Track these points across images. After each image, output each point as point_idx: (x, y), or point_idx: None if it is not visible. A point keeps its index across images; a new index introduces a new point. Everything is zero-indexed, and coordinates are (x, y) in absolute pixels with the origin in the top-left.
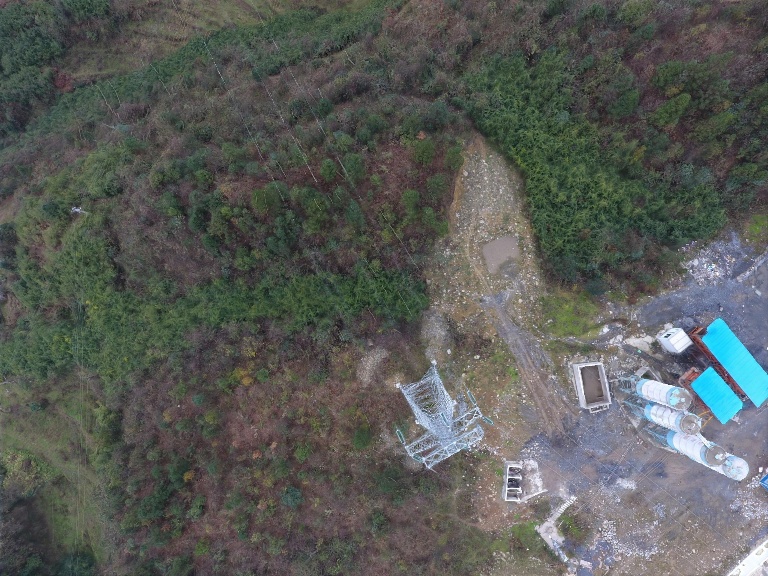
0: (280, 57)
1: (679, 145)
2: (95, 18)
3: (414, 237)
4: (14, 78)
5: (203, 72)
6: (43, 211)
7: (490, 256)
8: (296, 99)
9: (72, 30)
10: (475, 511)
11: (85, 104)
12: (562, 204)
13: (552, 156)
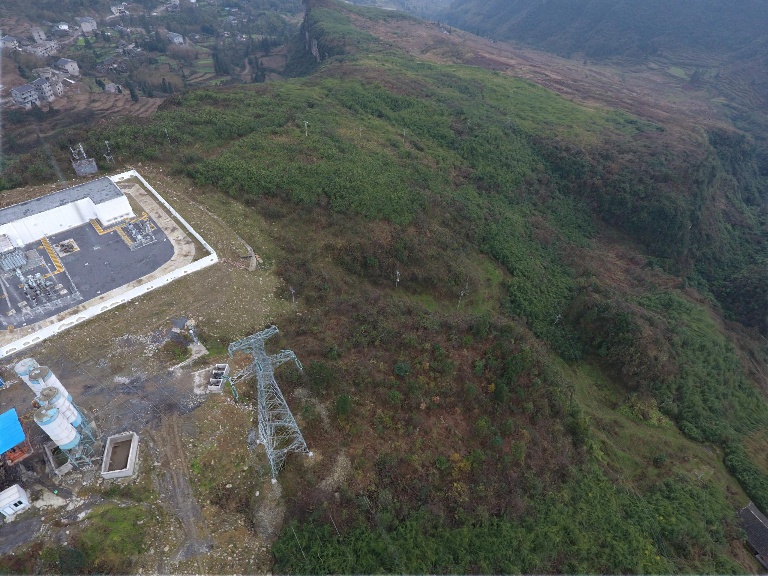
0: None
1: None
2: None
3: None
4: None
5: None
6: None
7: None
8: None
9: None
10: None
11: None
12: None
13: None
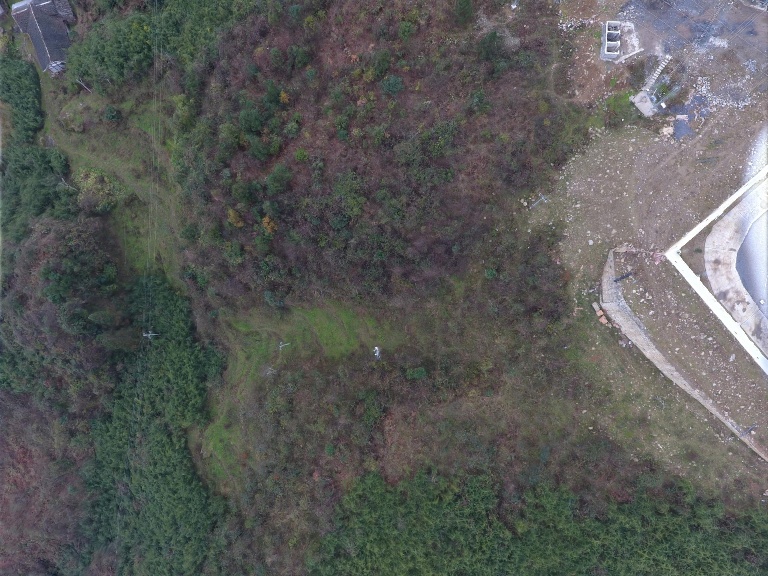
0: None
1: None
2: None
3: None
4: None
5: None
6: None
7: None
8: None
9: None
10: (572, 84)
11: None
12: None
13: None
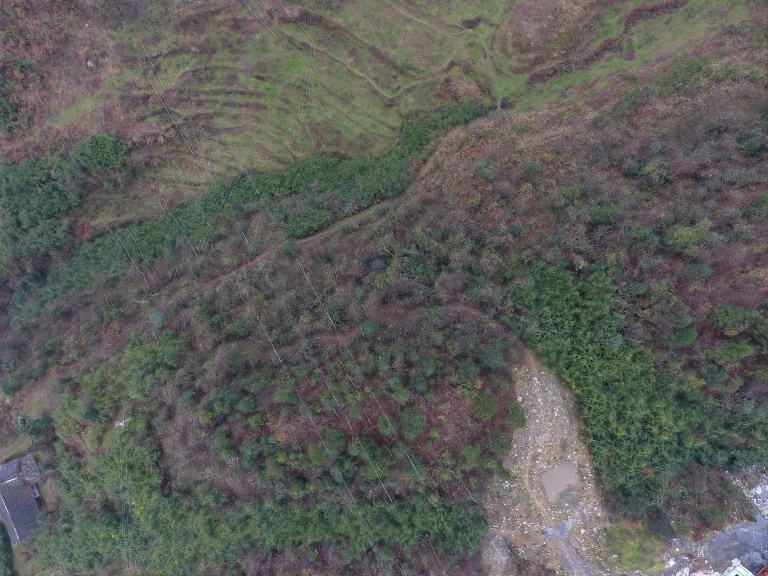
0: (308, 222)
1: (739, 379)
2: (112, 172)
3: (473, 476)
4: (33, 233)
5: (227, 229)
6: (82, 413)
7: (549, 485)
8: (336, 302)
9: (88, 180)
10: None
11: (107, 256)
12: (622, 437)
13: (607, 381)
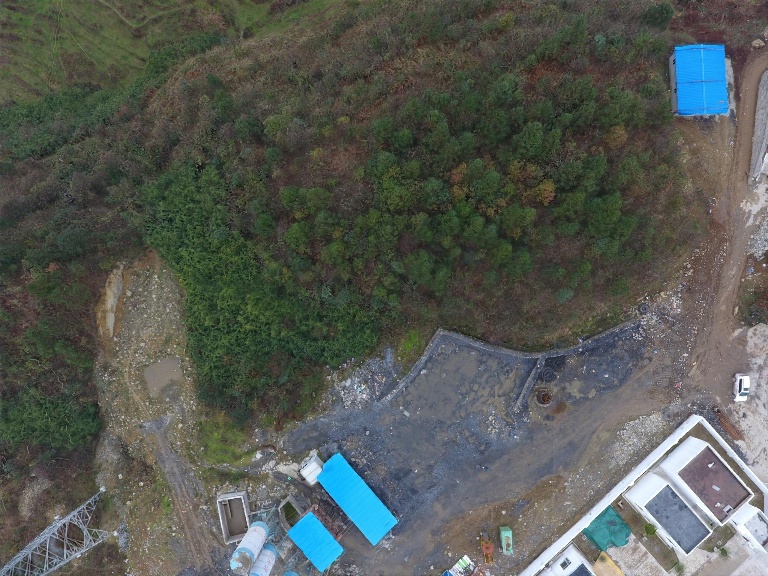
0: (30, 145)
1: (318, 266)
2: None
3: (64, 366)
4: None
5: None
6: None
7: (152, 379)
8: None
9: None
10: None
11: None
12: (212, 327)
13: (211, 274)
